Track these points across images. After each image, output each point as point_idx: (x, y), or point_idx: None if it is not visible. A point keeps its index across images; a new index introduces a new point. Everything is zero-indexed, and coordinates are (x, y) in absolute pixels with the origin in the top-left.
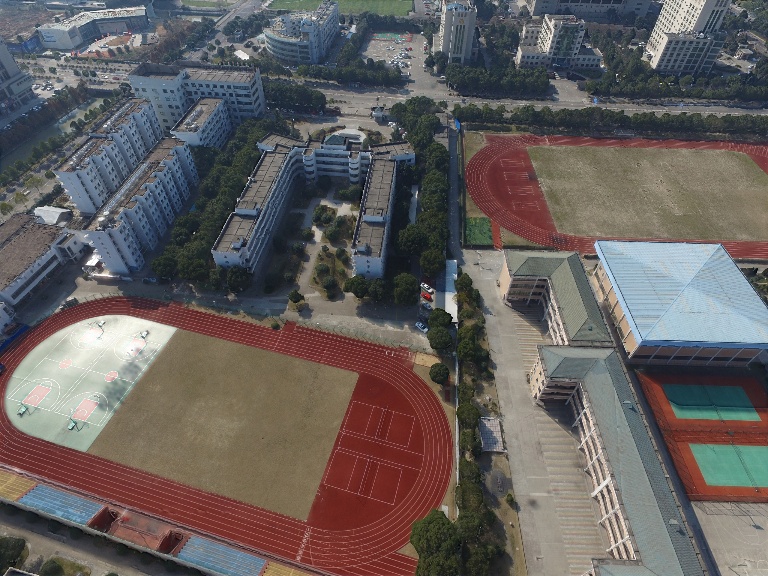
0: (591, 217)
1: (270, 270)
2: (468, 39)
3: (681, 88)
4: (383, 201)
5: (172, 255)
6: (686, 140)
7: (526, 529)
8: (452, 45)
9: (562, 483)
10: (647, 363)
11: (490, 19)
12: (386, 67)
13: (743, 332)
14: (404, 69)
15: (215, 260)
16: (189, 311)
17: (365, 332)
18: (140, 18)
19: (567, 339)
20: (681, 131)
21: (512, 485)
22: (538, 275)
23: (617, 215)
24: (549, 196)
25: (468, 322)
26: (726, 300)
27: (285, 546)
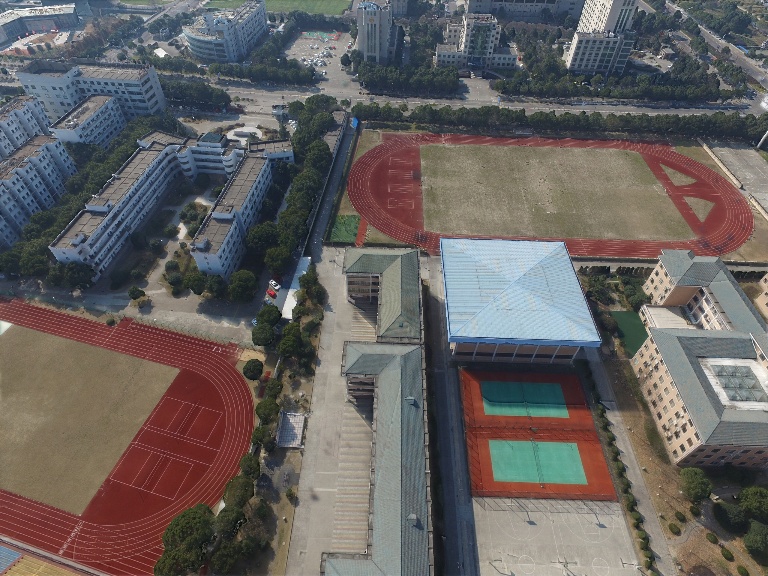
0: (463, 215)
1: (123, 267)
2: (383, 38)
3: (592, 87)
4: (240, 198)
5: (19, 251)
6: (583, 139)
7: (299, 524)
8: (365, 44)
9: (349, 479)
10: (472, 360)
11: (420, 18)
12: (299, 65)
13: (554, 329)
14: (322, 67)
15: (56, 256)
16: (29, 307)
17: (199, 328)
18: (68, 16)
19: (377, 336)
20: (580, 130)
21: (298, 480)
22: (370, 272)
23: (489, 213)
24: (427, 194)
25: (306, 319)
26: (548, 297)
27: (51, 540)
